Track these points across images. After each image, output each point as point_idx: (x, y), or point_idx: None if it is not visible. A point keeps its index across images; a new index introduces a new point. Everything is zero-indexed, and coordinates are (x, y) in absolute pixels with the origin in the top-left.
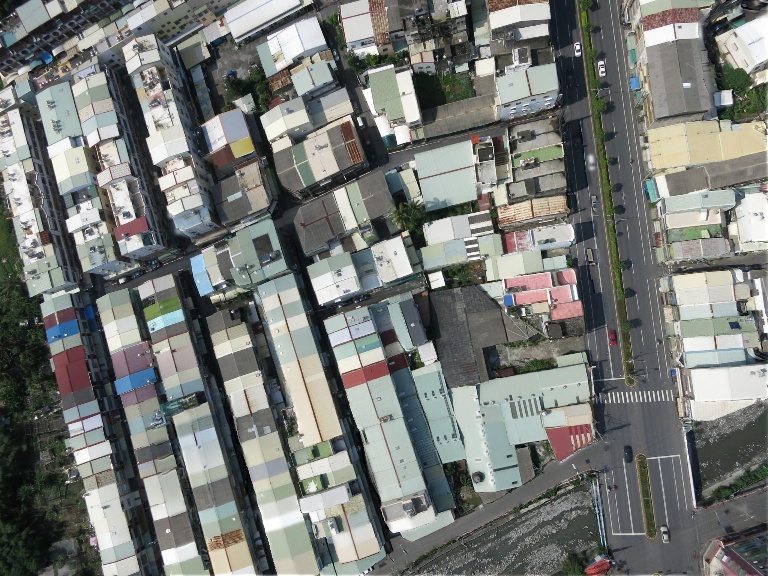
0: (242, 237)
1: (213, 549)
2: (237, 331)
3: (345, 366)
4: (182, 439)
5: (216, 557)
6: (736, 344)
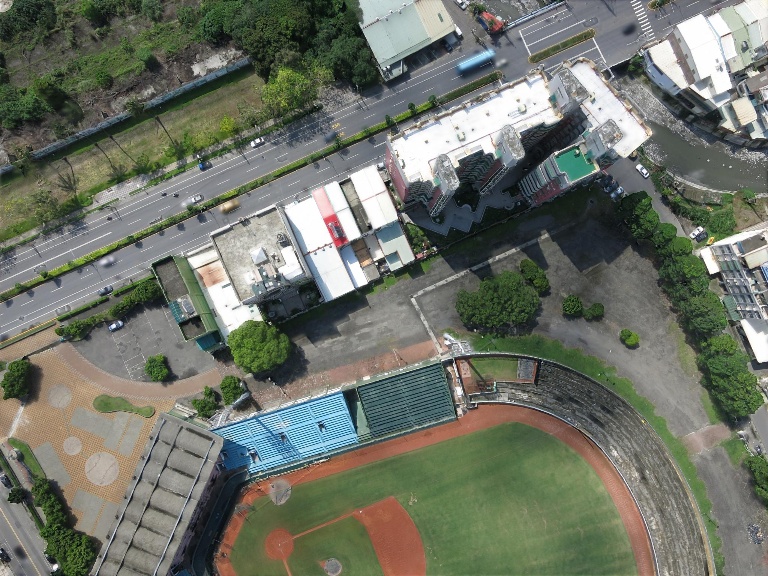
0: None
1: None
2: None
3: None
4: None
5: None
6: (729, 54)
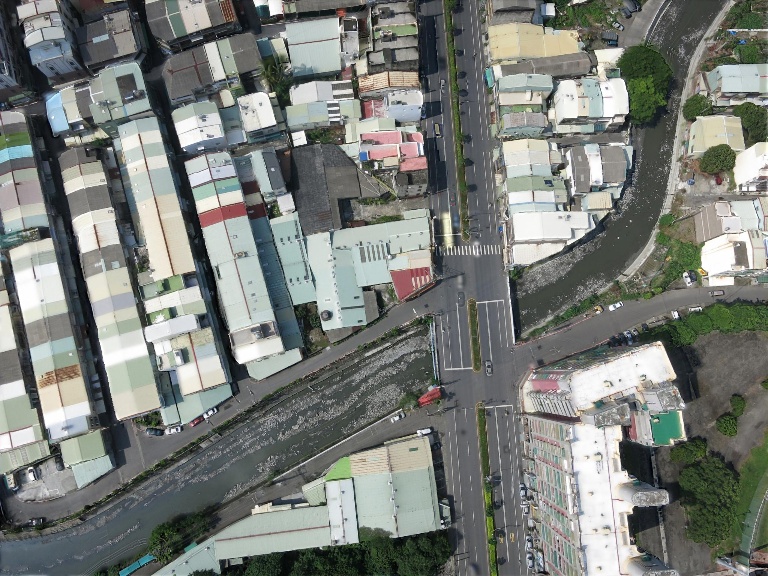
0: (105, 75)
1: (43, 386)
2: (91, 168)
3: (203, 206)
4: (18, 274)
5: (46, 394)
6: (549, 199)
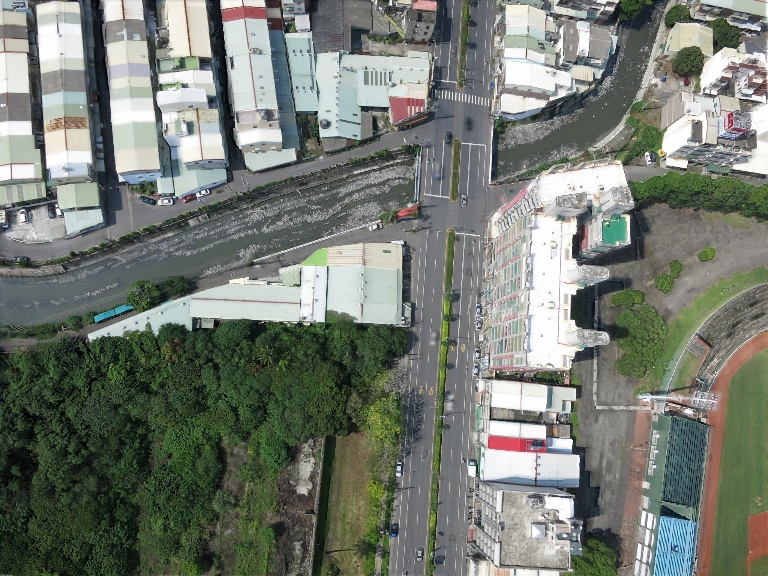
0: None
1: (50, 131)
2: None
3: (227, 3)
4: (42, 27)
5: (52, 137)
6: (540, 60)
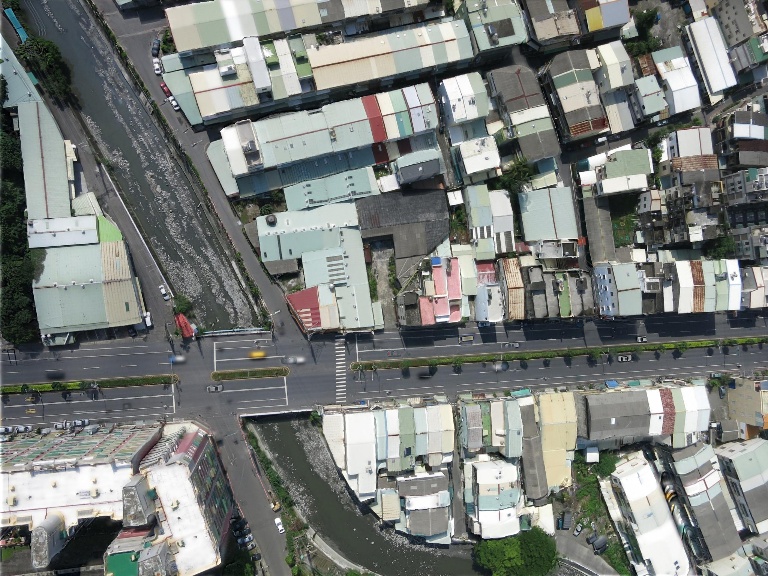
0: (513, 8)
1: None
2: None
3: (384, 99)
4: None
5: None
6: (391, 453)
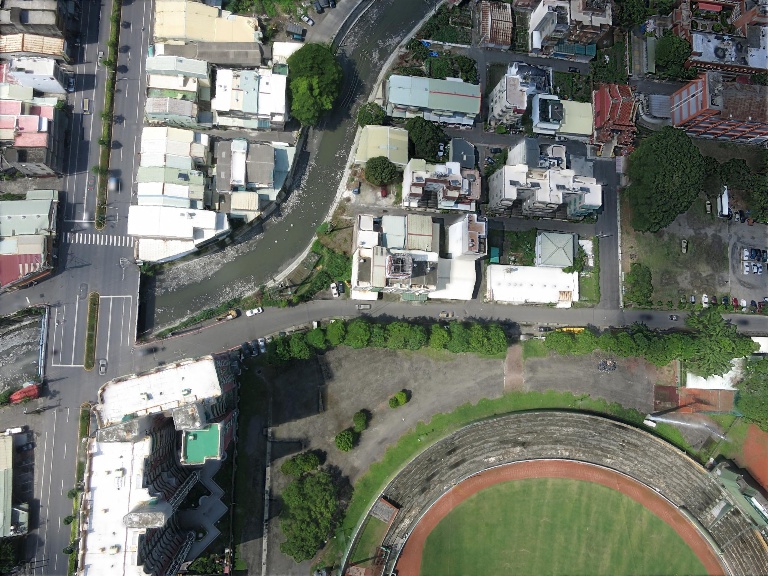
0: None
1: None
2: None
3: None
4: None
5: None
6: (183, 194)
